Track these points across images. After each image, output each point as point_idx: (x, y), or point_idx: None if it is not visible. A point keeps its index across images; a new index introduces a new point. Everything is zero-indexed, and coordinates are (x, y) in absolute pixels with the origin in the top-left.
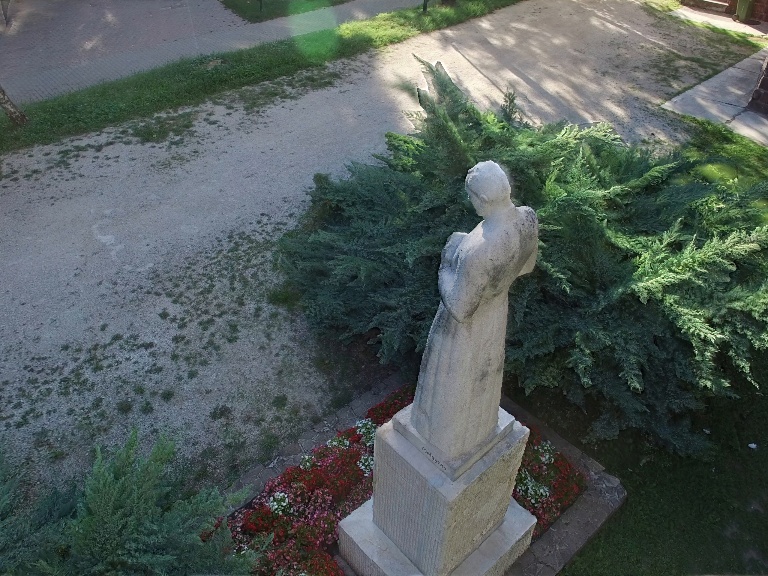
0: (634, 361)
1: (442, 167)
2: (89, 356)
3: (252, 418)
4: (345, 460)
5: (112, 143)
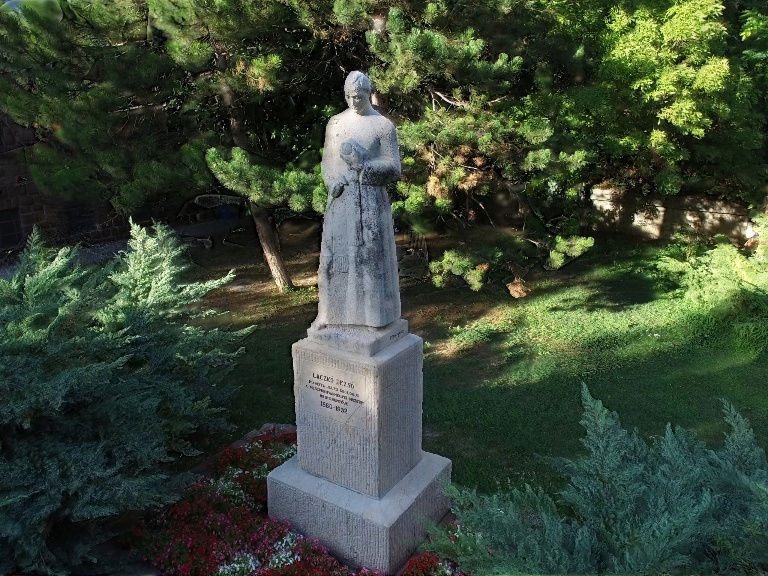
0: (218, 332)
1: None
2: None
3: None
4: None
5: None
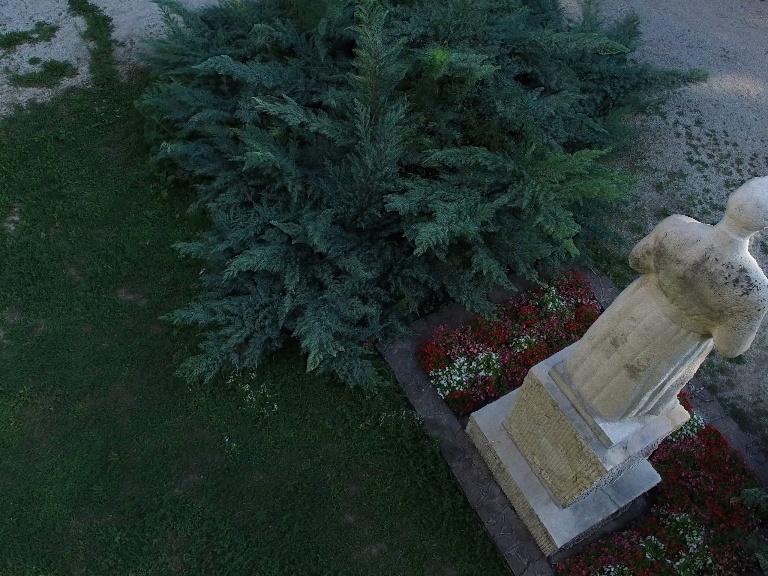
0: None
1: None
2: None
3: None
4: None
5: None
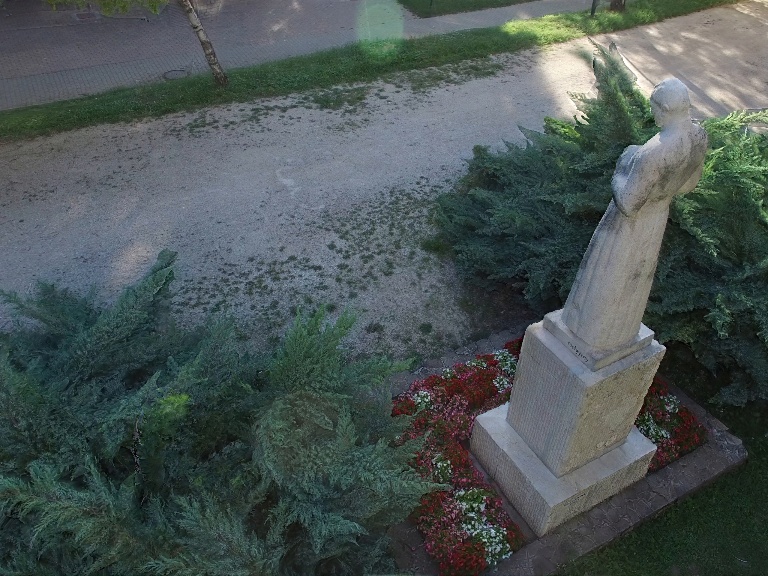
0: None
1: (607, 132)
2: (269, 269)
3: (401, 337)
4: (482, 377)
5: (296, 106)
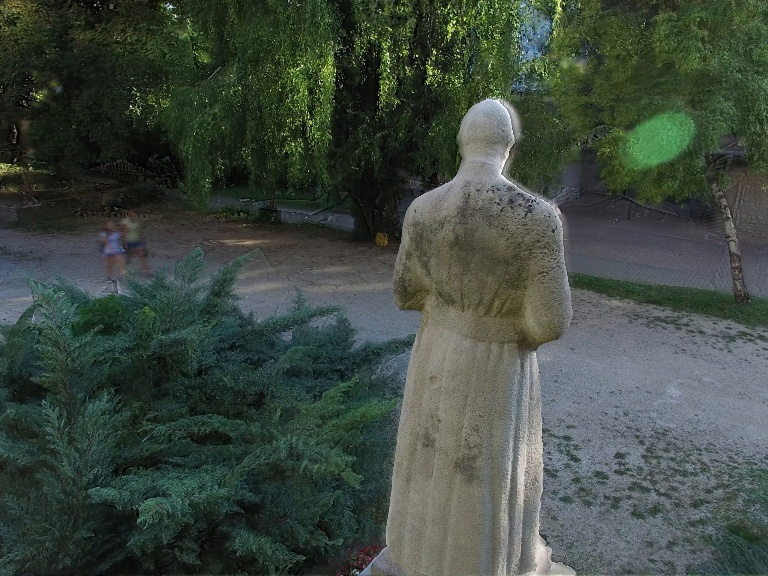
0: None
1: None
2: None
3: None
4: None
5: None
